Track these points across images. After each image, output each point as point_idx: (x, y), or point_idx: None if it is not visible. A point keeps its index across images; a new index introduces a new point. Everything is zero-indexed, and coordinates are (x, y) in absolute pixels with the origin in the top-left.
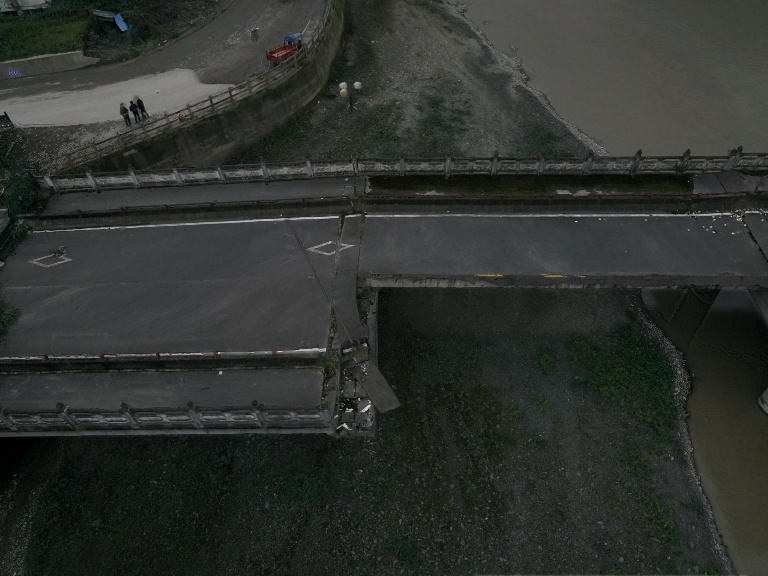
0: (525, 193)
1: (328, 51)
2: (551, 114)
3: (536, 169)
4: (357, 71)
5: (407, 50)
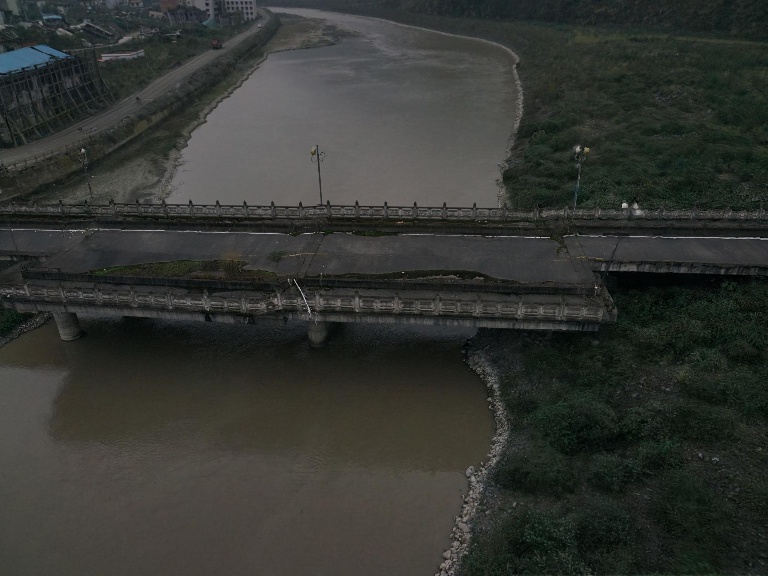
0: None
1: (41, 176)
2: None
3: (11, 211)
4: (60, 189)
5: (109, 181)
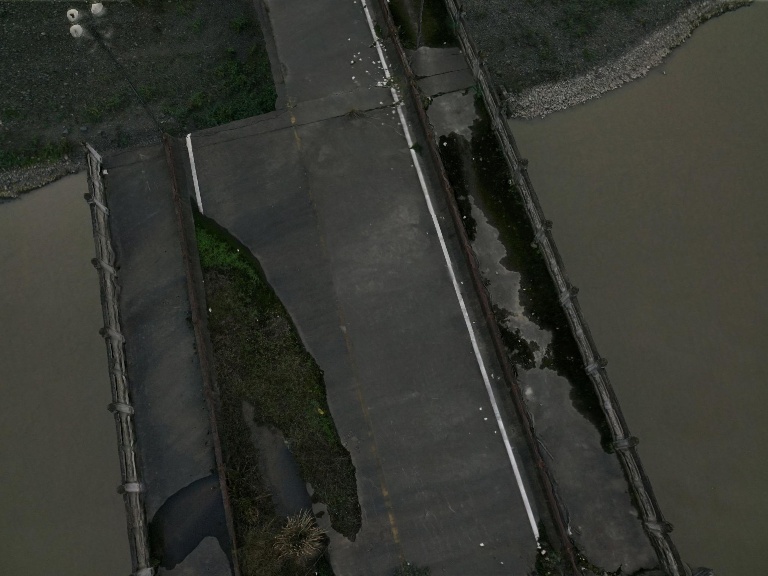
0: None
1: None
2: (689, 6)
3: None
4: None
5: None
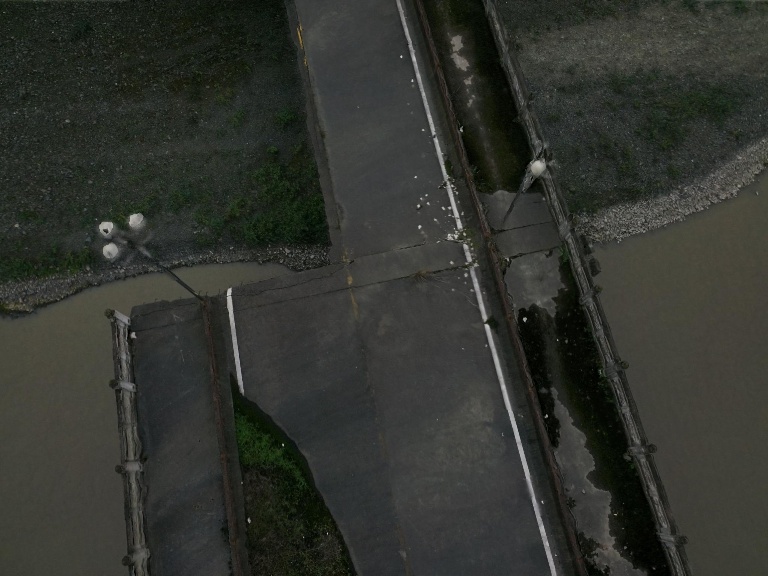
0: (444, 3)
1: None
2: None
3: None
4: None
5: None
